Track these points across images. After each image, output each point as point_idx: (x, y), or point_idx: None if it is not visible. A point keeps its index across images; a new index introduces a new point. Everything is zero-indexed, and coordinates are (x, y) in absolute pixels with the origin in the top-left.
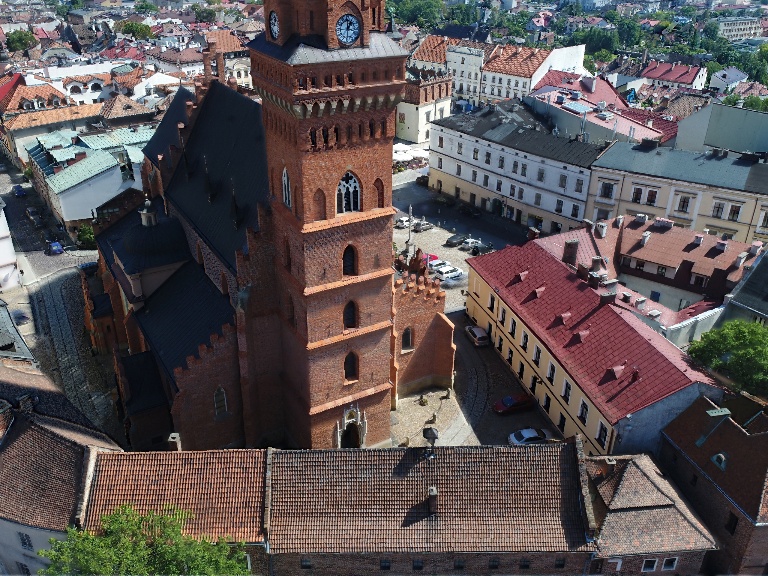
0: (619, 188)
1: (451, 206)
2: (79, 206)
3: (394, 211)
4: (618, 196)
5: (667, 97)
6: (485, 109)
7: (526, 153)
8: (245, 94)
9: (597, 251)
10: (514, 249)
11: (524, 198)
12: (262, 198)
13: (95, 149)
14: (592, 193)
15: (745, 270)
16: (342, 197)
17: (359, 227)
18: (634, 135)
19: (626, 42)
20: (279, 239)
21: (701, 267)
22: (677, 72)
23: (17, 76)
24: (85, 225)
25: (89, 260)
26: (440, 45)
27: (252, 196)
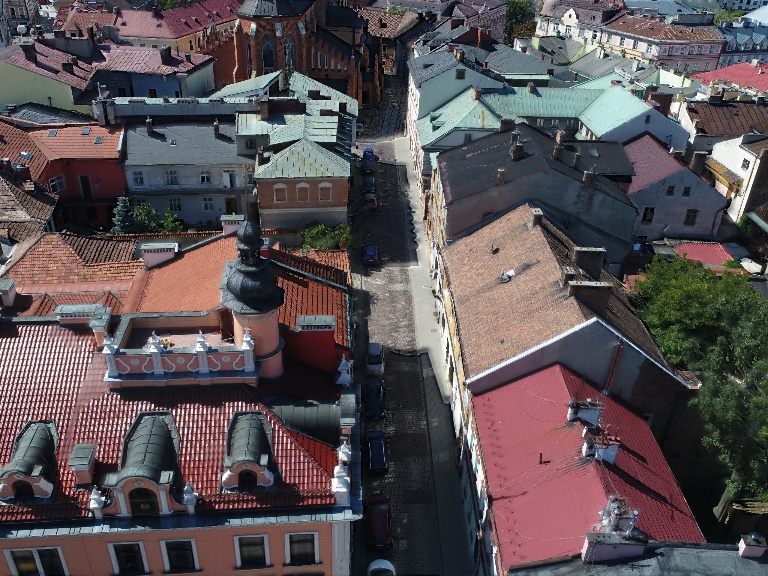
0: None
1: None
2: None
3: None
4: None
5: None
6: None
7: None
8: None
9: None
10: None
11: None
12: None
13: None
14: None
15: None
16: None
17: None
18: None
19: None
20: None
21: None
22: None
23: None
24: None
25: None
26: None
27: None
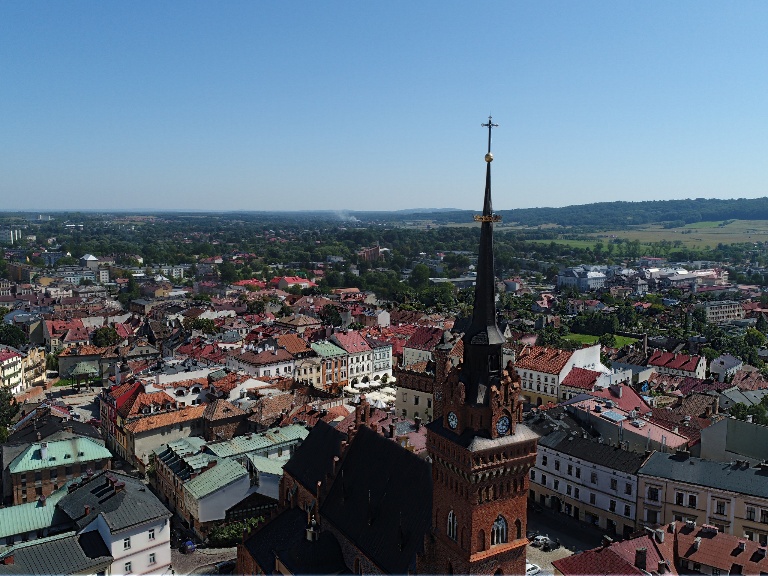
0: (663, 492)
1: None
2: (213, 509)
3: (528, 541)
4: (663, 499)
5: None
6: (536, 417)
7: (579, 459)
8: (382, 433)
9: (660, 555)
10: (593, 555)
11: (580, 497)
12: (423, 528)
13: (222, 457)
14: (641, 496)
15: None
16: (494, 533)
17: (505, 555)
18: (665, 441)
19: (625, 324)
20: (441, 562)
21: (749, 570)
22: (680, 361)
23: (138, 385)
24: (215, 526)
25: (219, 558)
26: None
27: (413, 525)
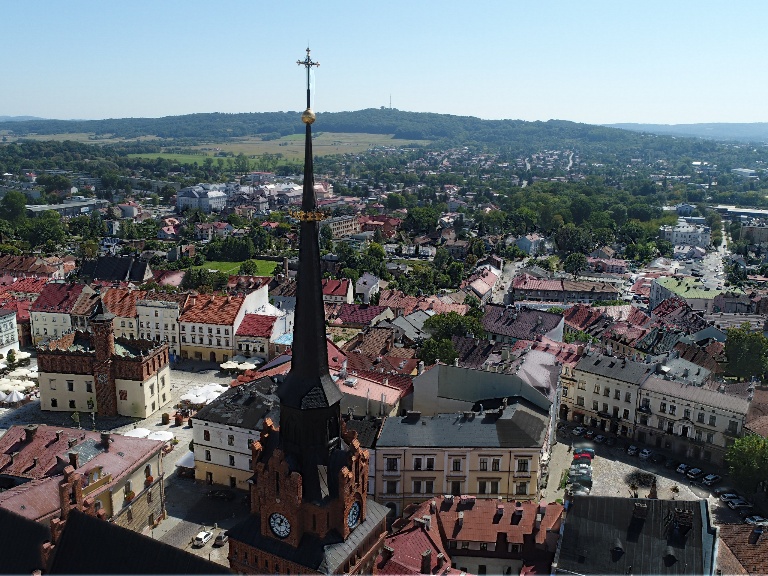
0: (402, 461)
1: (232, 499)
2: None
3: None
4: (402, 468)
5: (361, 333)
6: (245, 396)
7: None
8: (101, 509)
9: (435, 547)
10: None
11: None
12: None
13: None
14: (379, 469)
15: (548, 533)
16: None
17: None
18: None
19: (259, 247)
20: None
21: (513, 536)
22: (331, 286)
23: None
24: None
25: None
26: (125, 298)
27: None
